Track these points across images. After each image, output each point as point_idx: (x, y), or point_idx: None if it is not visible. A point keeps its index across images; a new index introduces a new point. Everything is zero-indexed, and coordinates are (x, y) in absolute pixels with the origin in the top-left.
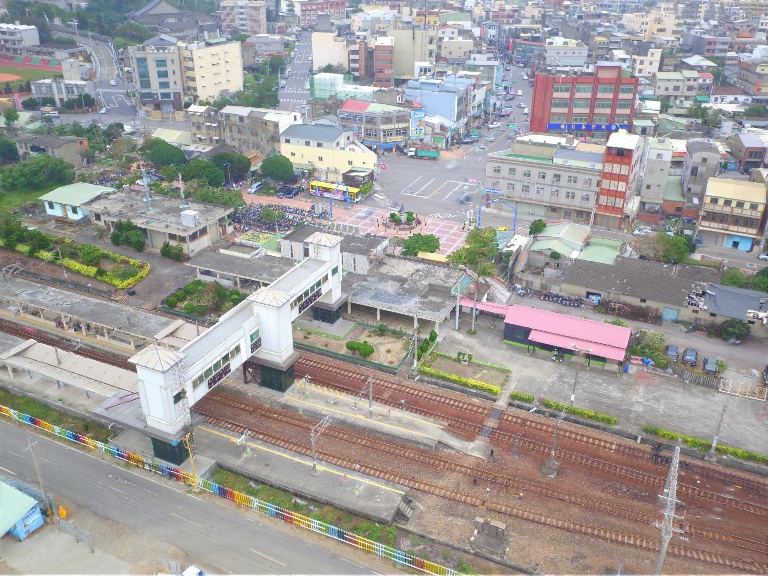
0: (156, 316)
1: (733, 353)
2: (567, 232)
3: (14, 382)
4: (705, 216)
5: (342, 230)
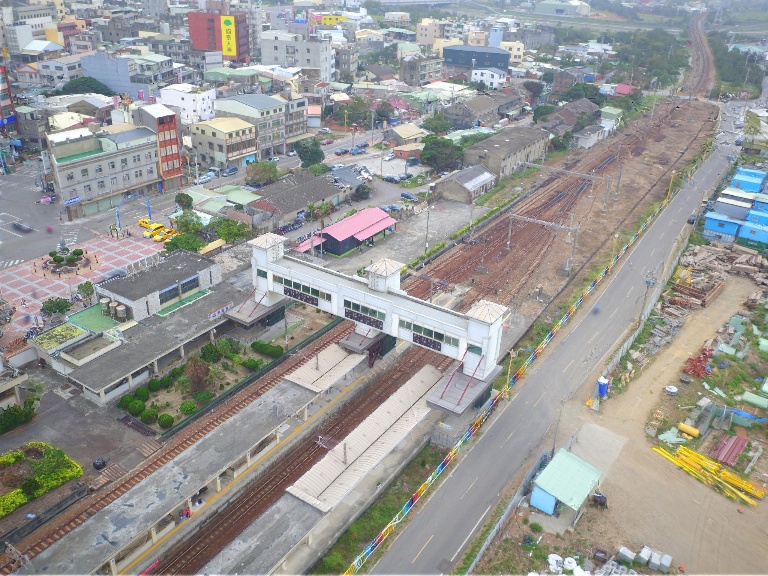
0: (261, 397)
1: (379, 201)
2: (203, 194)
3: (320, 540)
4: (228, 149)
5: (140, 267)
